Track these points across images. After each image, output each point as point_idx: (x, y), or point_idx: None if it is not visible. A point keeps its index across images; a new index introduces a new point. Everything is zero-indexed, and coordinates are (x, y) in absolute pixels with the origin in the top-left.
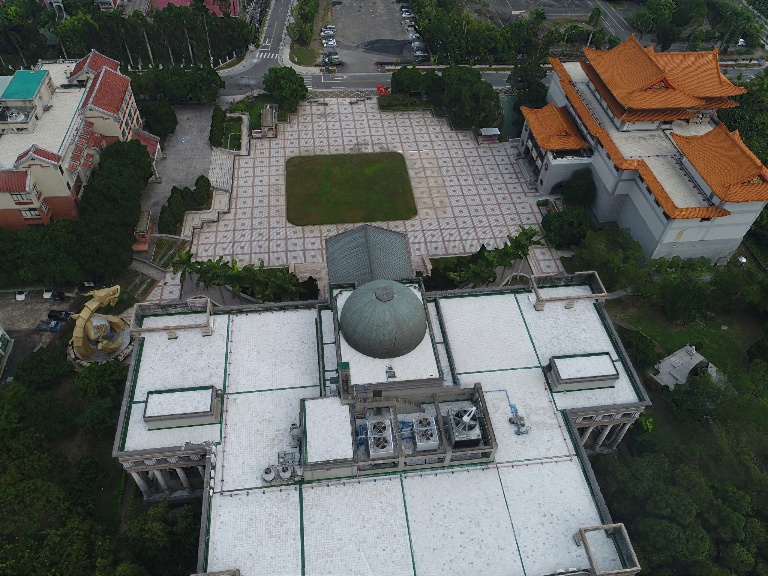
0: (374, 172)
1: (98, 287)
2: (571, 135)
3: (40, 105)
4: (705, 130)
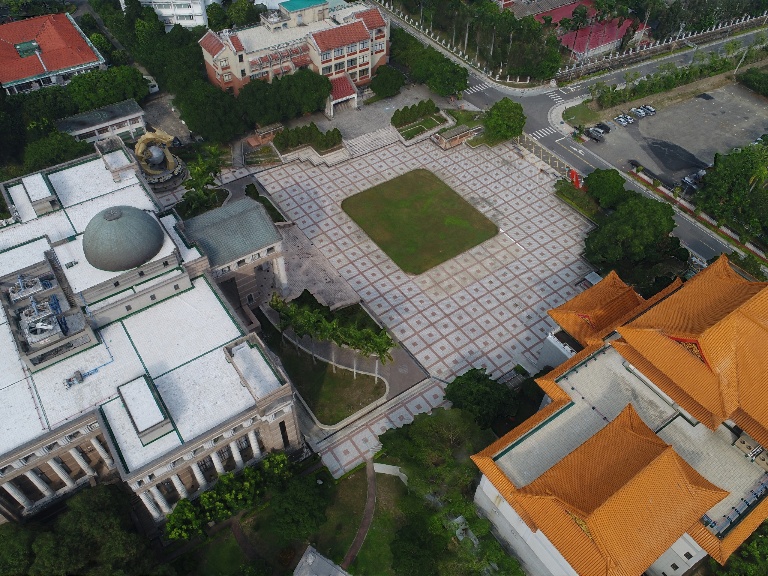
0: (452, 224)
1: (206, 144)
2: (595, 329)
3: (297, 20)
4: (738, 470)
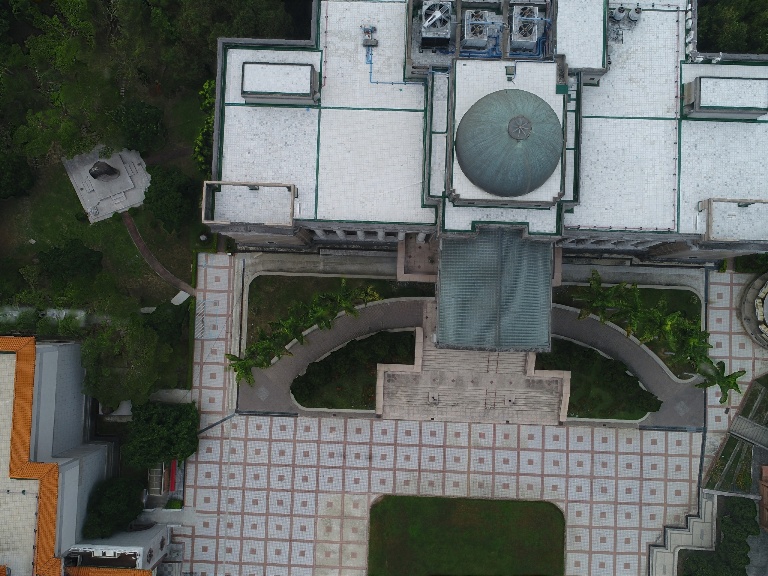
0: None
1: None
2: None
3: None
4: None
